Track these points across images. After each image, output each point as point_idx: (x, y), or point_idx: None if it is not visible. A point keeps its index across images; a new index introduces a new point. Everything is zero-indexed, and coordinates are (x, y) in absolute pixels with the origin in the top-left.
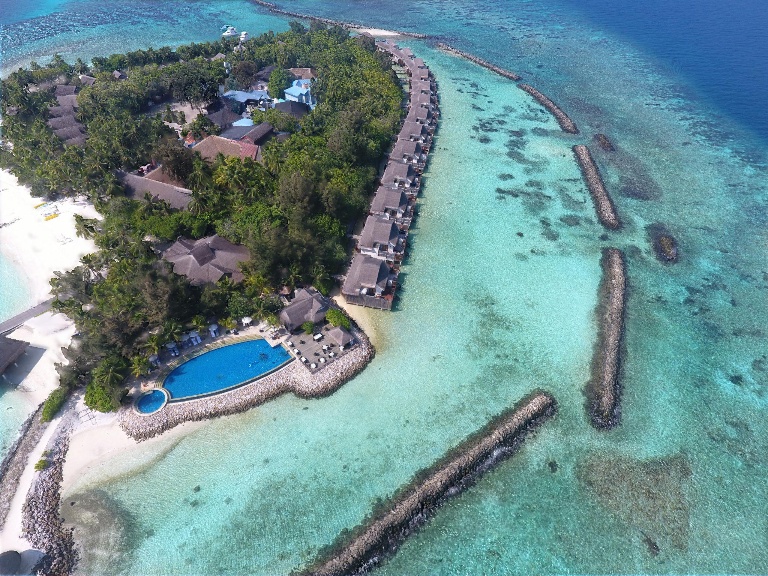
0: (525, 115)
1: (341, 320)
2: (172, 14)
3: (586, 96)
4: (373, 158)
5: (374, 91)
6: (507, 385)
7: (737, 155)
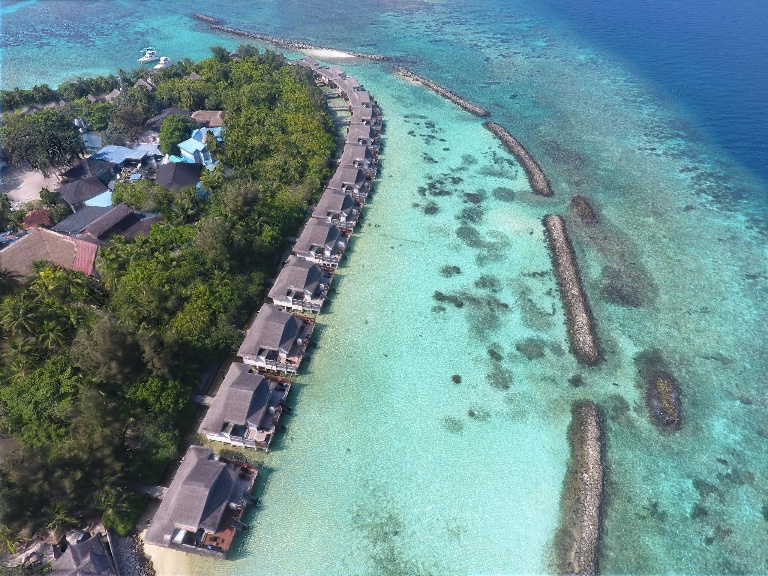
0: (488, 168)
1: None
2: (91, 33)
3: (566, 138)
4: (265, 255)
5: (292, 145)
6: None
7: (754, 225)
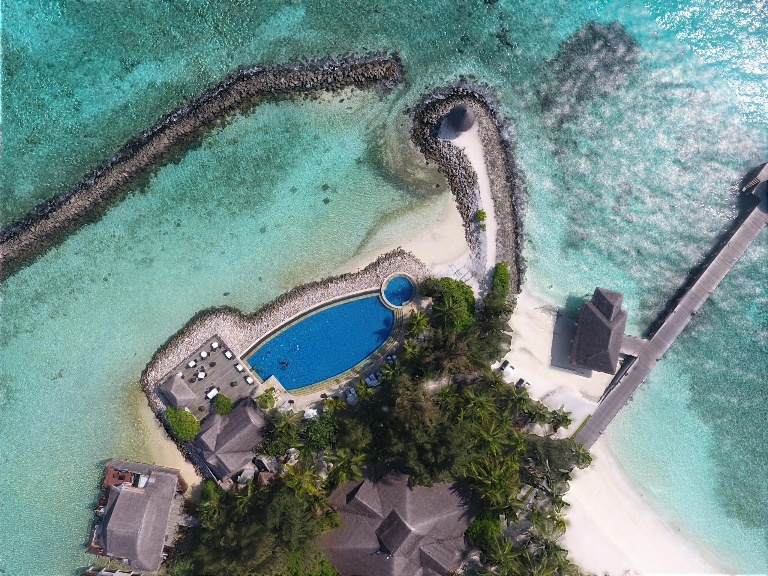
0: None
1: (176, 417)
2: None
3: None
4: None
5: None
6: None
7: None
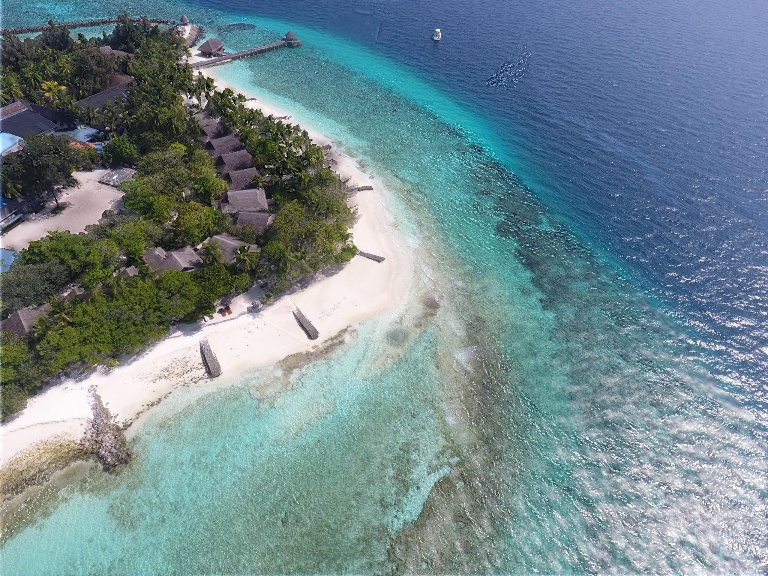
0: None
1: None
2: None
3: None
4: None
5: None
6: None
7: None
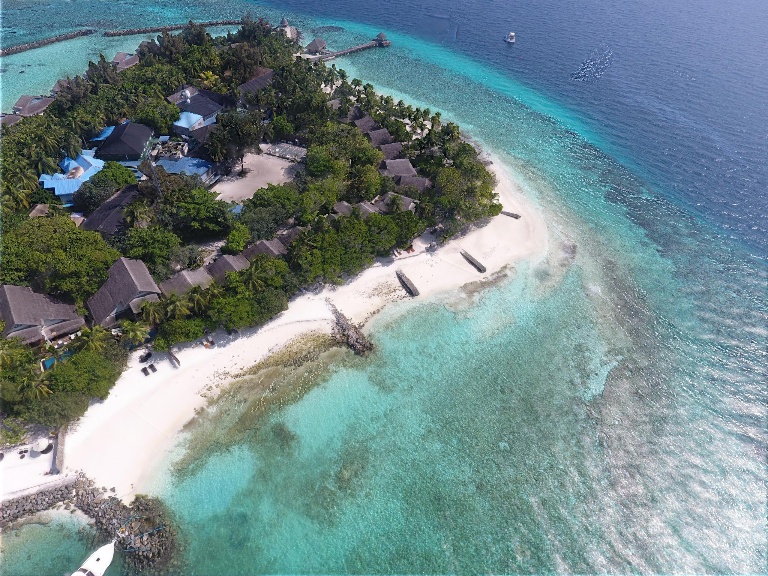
0: None
1: None
2: None
3: None
4: None
5: None
6: None
7: None
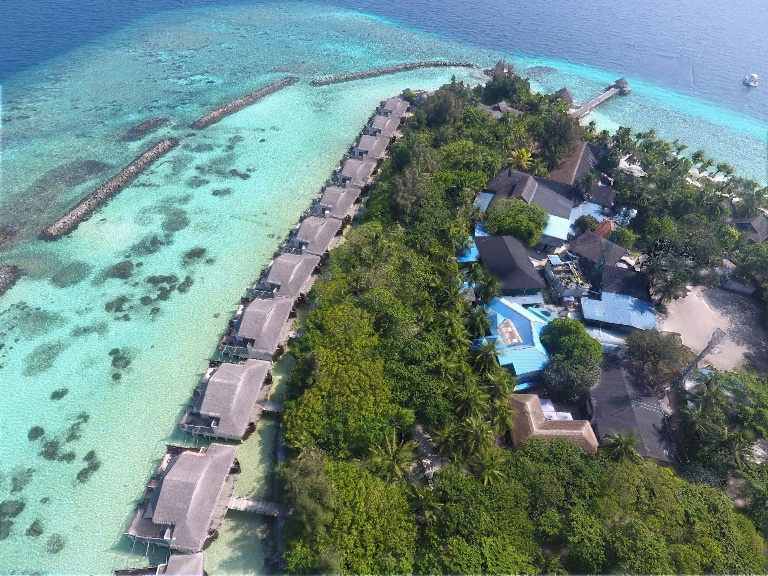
0: (35, 330)
1: (409, 93)
2: None
3: None
4: None
5: None
6: (329, 88)
7: None
